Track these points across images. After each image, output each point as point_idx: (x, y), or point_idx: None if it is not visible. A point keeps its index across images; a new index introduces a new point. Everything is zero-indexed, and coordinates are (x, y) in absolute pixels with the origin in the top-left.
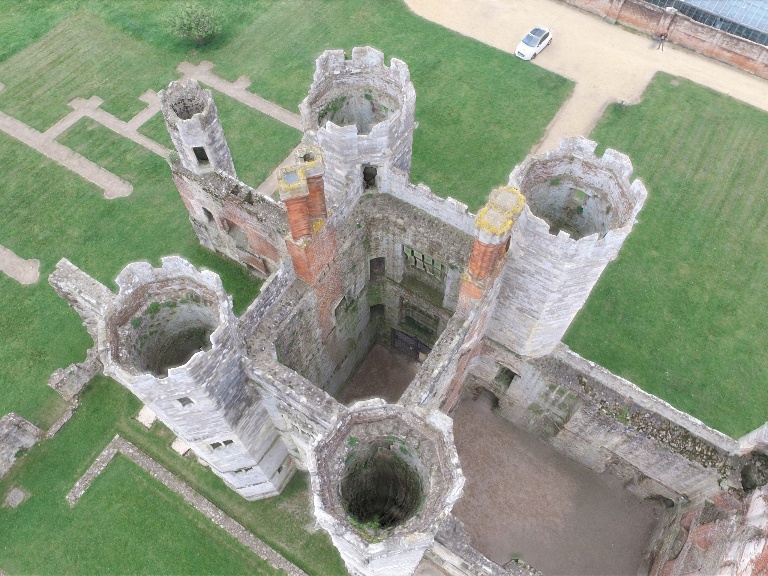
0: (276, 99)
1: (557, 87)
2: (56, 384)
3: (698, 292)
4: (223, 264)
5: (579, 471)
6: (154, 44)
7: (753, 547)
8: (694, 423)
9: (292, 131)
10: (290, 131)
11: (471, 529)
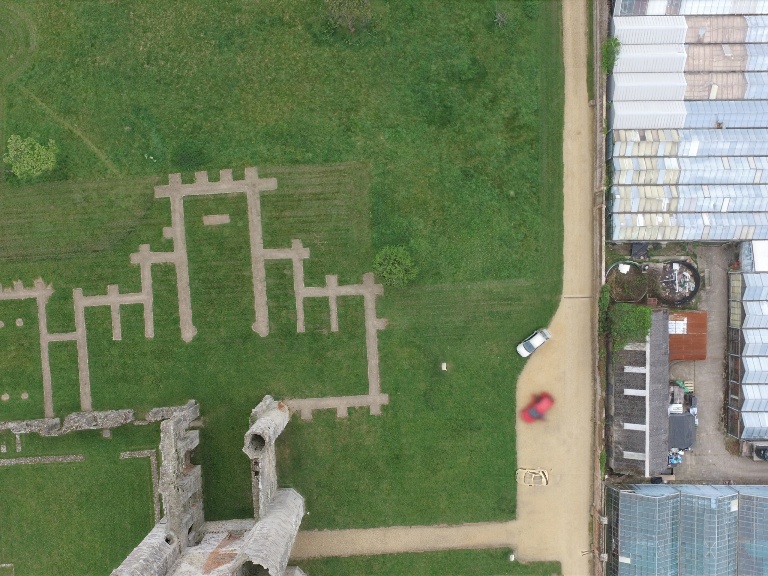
0: (382, 355)
1: (504, 511)
2: (148, 420)
3: None
4: None
5: None
6: (373, 241)
7: None
8: None
9: (365, 384)
10: (364, 383)
11: None
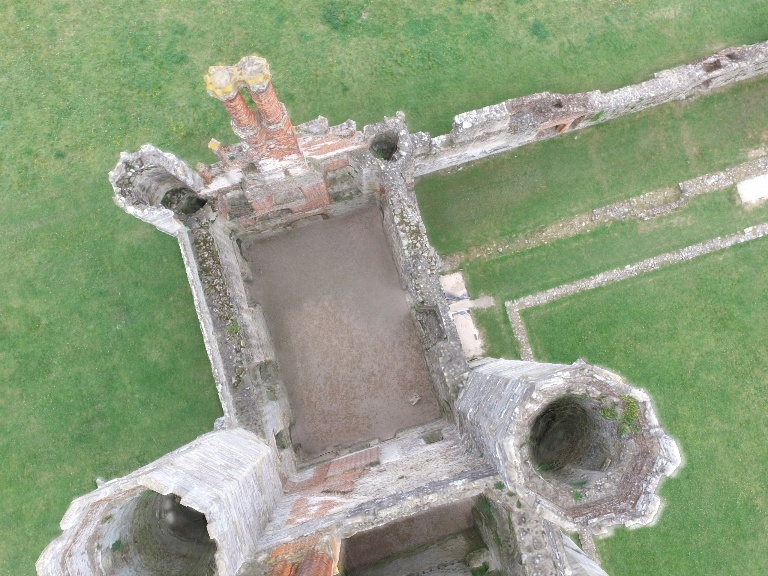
0: None
1: None
2: None
3: (2, 367)
4: None
5: (274, 321)
6: None
7: (269, 166)
8: (193, 273)
9: None
10: None
11: (396, 352)
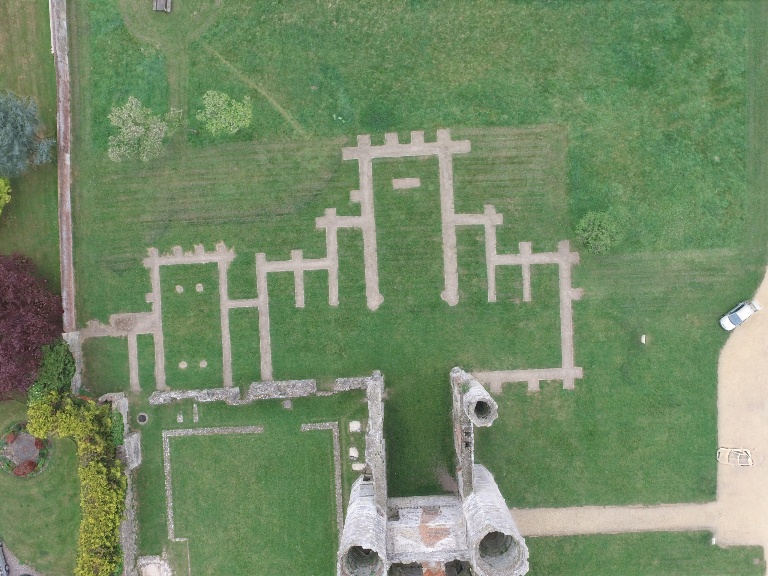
0: (577, 326)
1: (703, 492)
2: (336, 389)
3: None
4: (447, 394)
5: None
6: (569, 207)
7: None
8: None
9: (558, 357)
10: (558, 356)
11: None
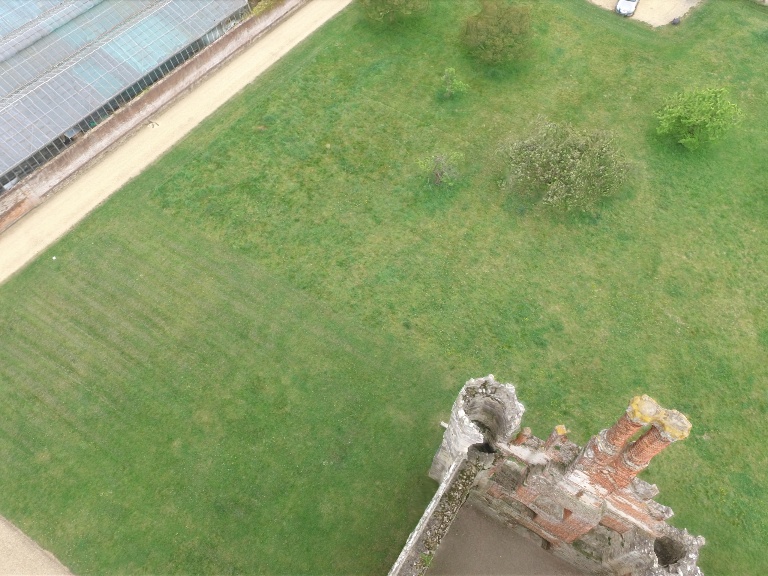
0: None
1: None
2: None
3: (233, 409)
4: None
5: None
6: None
7: (578, 478)
8: None
9: None
10: None
11: None
